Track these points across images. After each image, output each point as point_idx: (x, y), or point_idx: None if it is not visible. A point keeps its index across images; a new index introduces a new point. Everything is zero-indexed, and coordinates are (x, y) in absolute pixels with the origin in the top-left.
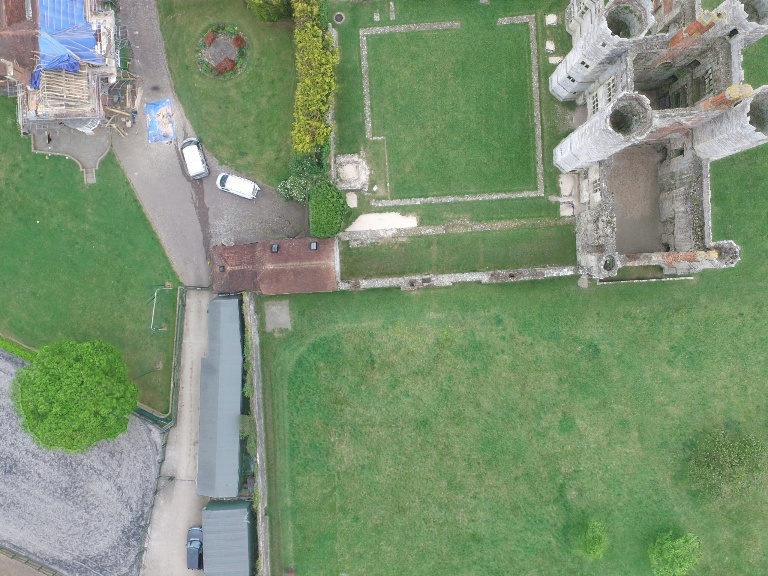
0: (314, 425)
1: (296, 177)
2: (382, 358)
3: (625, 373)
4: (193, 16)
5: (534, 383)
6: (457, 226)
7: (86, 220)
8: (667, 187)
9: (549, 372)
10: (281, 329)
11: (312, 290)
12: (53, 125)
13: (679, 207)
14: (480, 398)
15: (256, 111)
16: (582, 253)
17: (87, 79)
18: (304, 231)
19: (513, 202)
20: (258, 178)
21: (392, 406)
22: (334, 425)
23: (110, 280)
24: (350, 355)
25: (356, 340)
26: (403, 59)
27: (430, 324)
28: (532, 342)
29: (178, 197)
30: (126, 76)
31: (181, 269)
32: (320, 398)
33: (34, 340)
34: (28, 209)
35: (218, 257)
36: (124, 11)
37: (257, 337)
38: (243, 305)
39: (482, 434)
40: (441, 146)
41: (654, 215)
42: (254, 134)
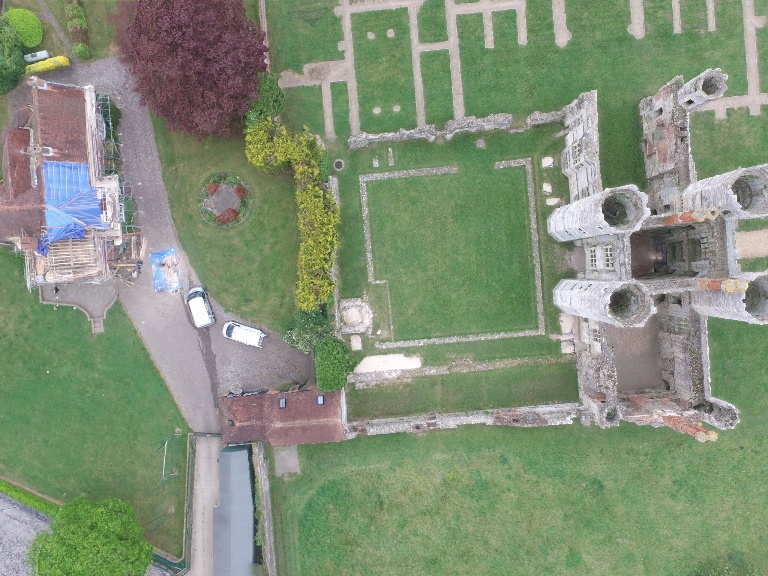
0: (325, 566)
1: (301, 330)
2: (390, 499)
3: (629, 508)
4: (195, 166)
5: (540, 520)
6: (460, 366)
7: (95, 369)
8: (666, 327)
9: (555, 509)
10: (290, 473)
11: (320, 441)
12: (61, 284)
13: (678, 353)
14: (488, 536)
15: (260, 258)
16: (584, 394)
17: (93, 242)
18: (310, 382)
19: (515, 341)
20: (263, 324)
21: (401, 546)
22: (345, 566)
23: (120, 427)
24: (359, 497)
25: (364, 482)
26: (403, 204)
27: (437, 465)
28: (537, 480)
29: (185, 345)
30: (131, 231)
31: (190, 416)
32: (330, 540)
33: (47, 487)
34: (38, 359)
35: (227, 410)
36: (127, 163)
37: (267, 483)
38: (253, 456)
39: (490, 571)
40: (442, 288)
41: (654, 351)
42: (258, 281)
